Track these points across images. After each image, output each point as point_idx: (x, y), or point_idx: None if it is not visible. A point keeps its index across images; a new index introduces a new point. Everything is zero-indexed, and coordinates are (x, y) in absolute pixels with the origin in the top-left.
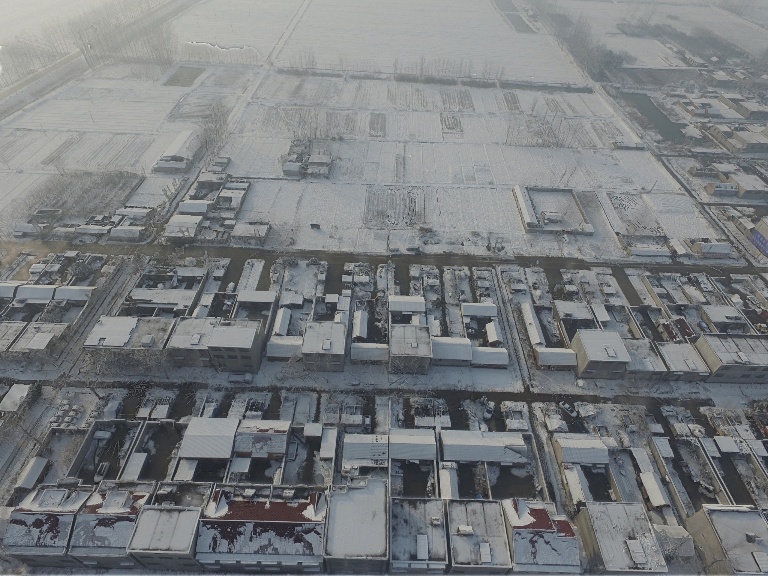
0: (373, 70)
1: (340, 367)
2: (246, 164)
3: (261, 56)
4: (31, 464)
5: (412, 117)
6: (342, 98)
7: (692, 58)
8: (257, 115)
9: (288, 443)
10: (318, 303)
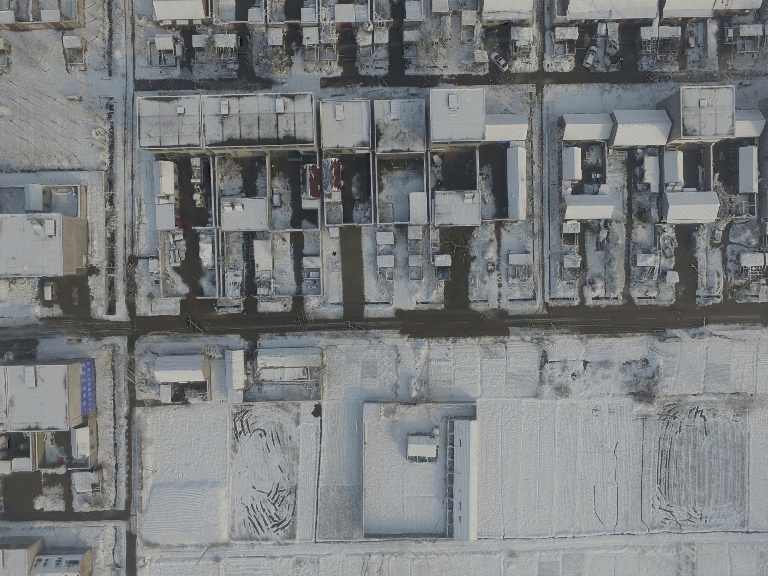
0: None
1: None
2: None
3: None
4: None
5: None
6: None
7: None
8: None
9: None
10: None
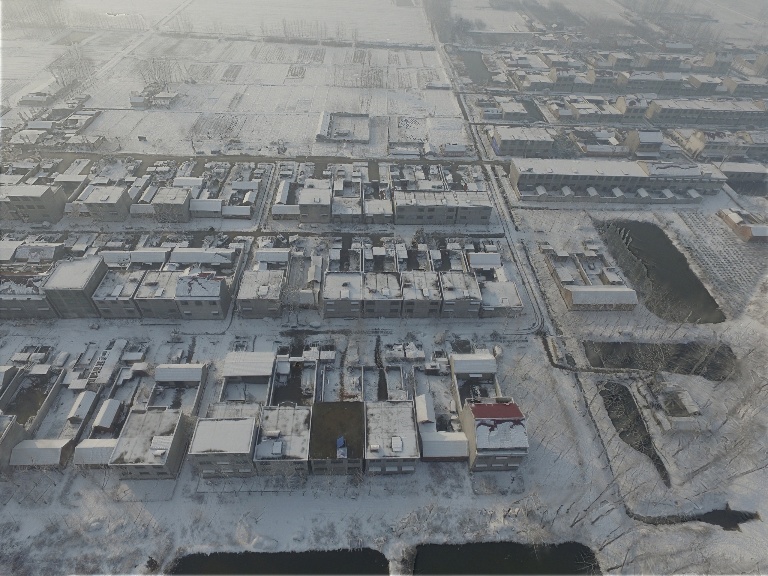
0: (246, 33)
1: (119, 217)
2: (103, 100)
3: (150, 23)
4: None
5: (265, 68)
6: (210, 54)
7: (535, 25)
8: (128, 66)
9: (59, 255)
10: (122, 184)
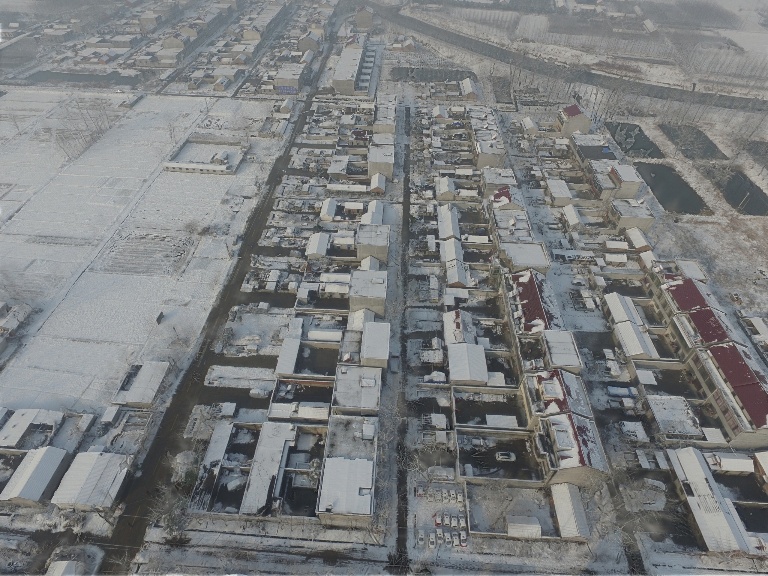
0: None
1: None
2: None
3: None
4: (517, 526)
5: None
6: None
7: None
8: None
9: None
10: None
